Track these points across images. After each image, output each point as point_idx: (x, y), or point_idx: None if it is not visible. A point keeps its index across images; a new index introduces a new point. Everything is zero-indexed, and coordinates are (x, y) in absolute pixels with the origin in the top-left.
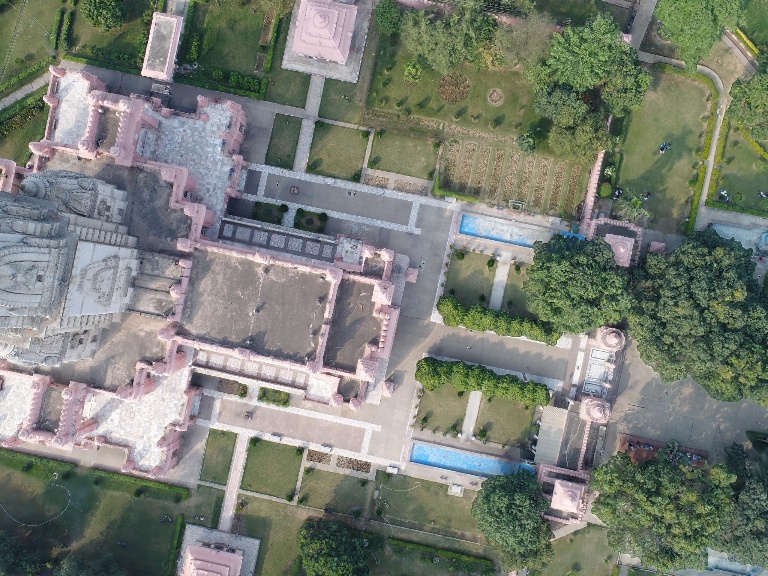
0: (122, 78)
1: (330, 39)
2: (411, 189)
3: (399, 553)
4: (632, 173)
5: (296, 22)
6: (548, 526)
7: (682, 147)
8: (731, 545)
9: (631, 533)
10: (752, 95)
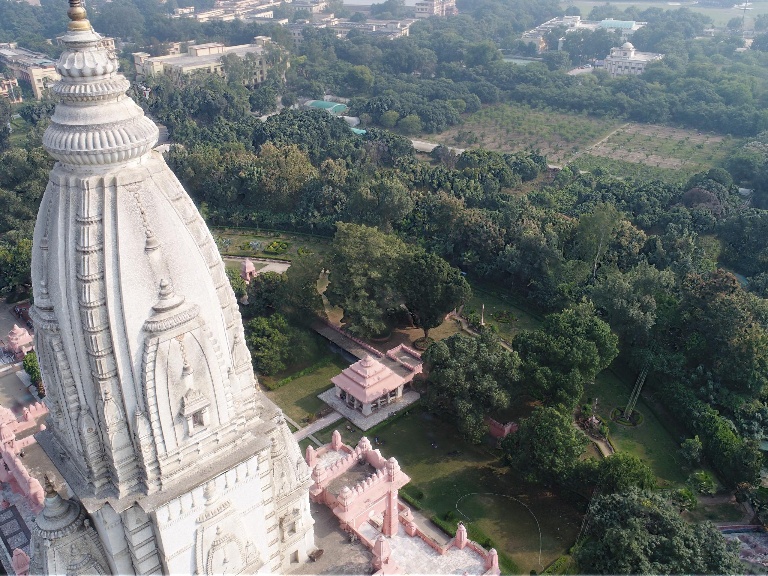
0: None
1: None
2: None
3: None
4: None
5: None
6: None
7: None
8: None
9: None
10: None
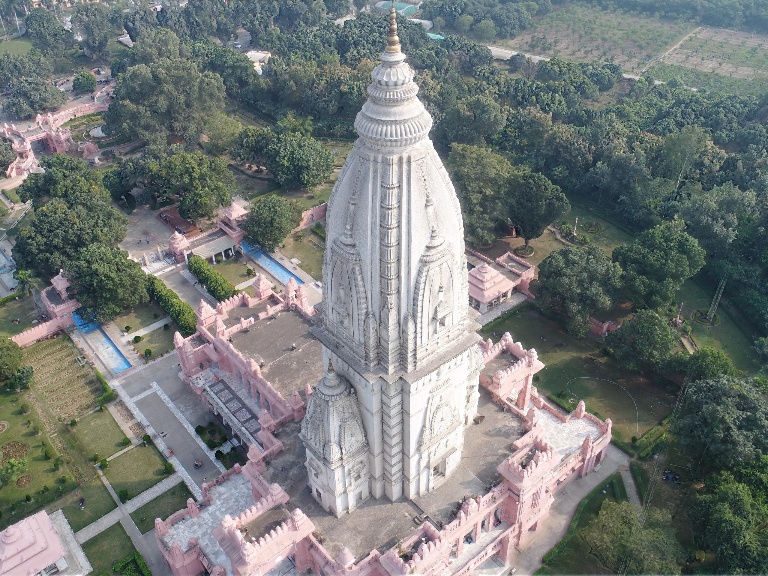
0: None
1: None
2: (125, 411)
3: None
4: None
5: (31, 573)
6: None
7: None
8: None
9: (220, 175)
10: None
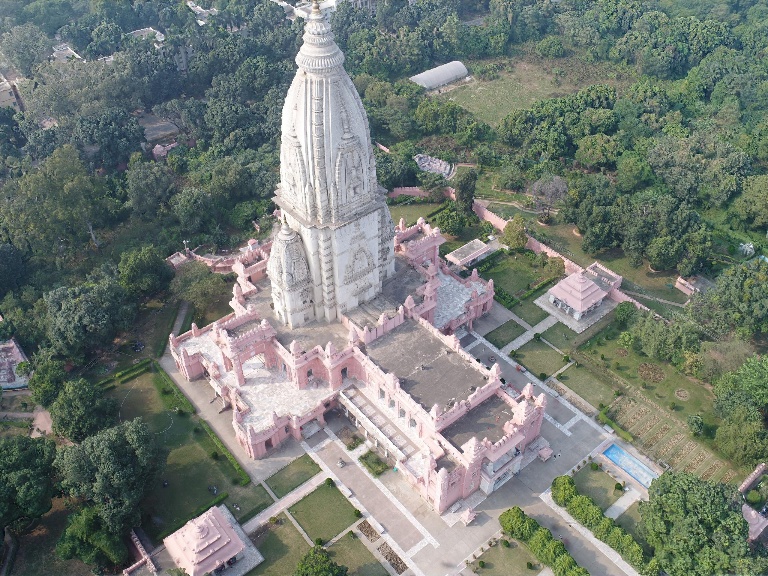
0: None
1: (579, 292)
2: (580, 407)
3: None
4: None
5: None
6: None
7: None
8: None
9: None
10: None
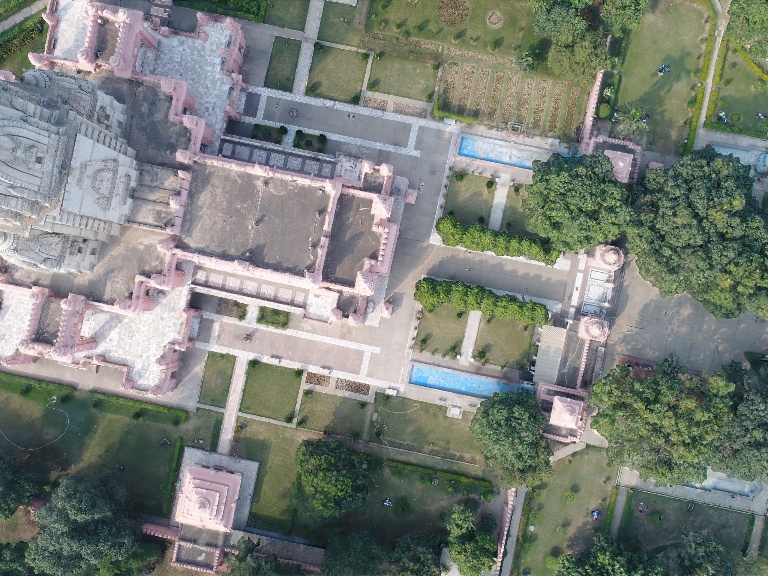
0: (121, 1)
1: None
2: (410, 111)
3: (398, 474)
4: (631, 95)
5: None
6: (547, 443)
7: (680, 69)
8: (729, 459)
9: (630, 444)
10: (750, 10)
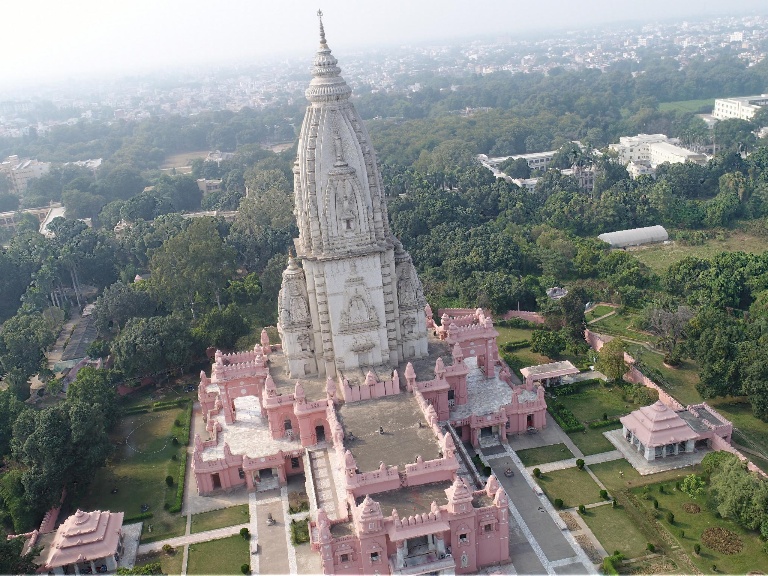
0: None
1: (652, 421)
2: (589, 549)
3: None
4: None
5: None
6: None
7: None
8: None
9: None
10: None
